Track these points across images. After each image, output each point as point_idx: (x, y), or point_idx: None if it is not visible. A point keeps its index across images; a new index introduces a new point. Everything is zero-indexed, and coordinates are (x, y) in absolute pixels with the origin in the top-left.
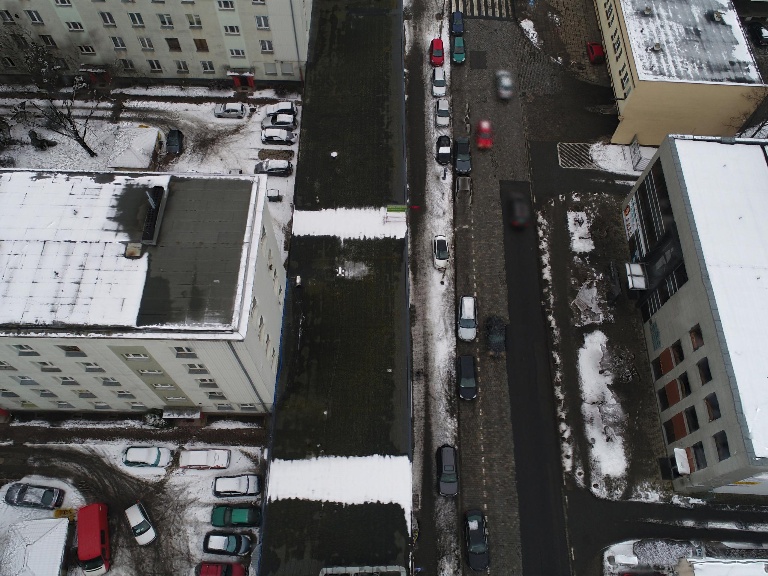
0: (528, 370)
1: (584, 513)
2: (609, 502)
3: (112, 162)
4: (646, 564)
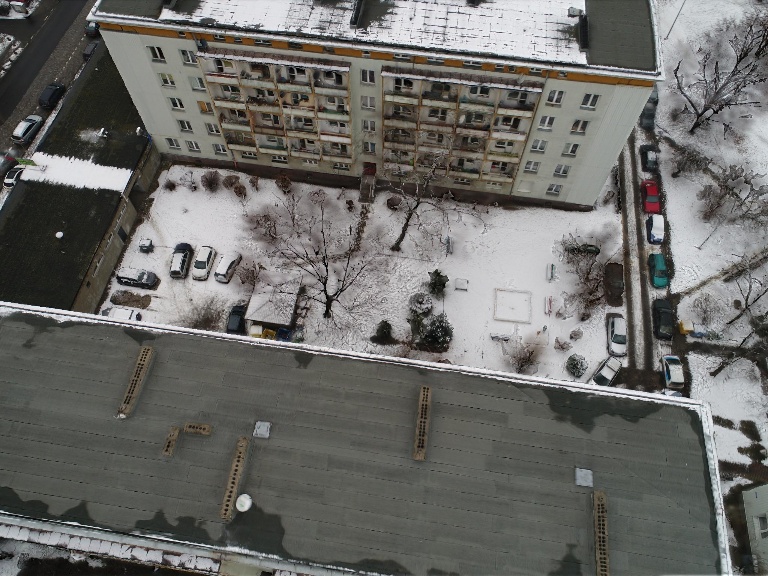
0: (6, 98)
1: (26, 30)
2: (8, 33)
3: (296, 278)
4: (7, 1)
